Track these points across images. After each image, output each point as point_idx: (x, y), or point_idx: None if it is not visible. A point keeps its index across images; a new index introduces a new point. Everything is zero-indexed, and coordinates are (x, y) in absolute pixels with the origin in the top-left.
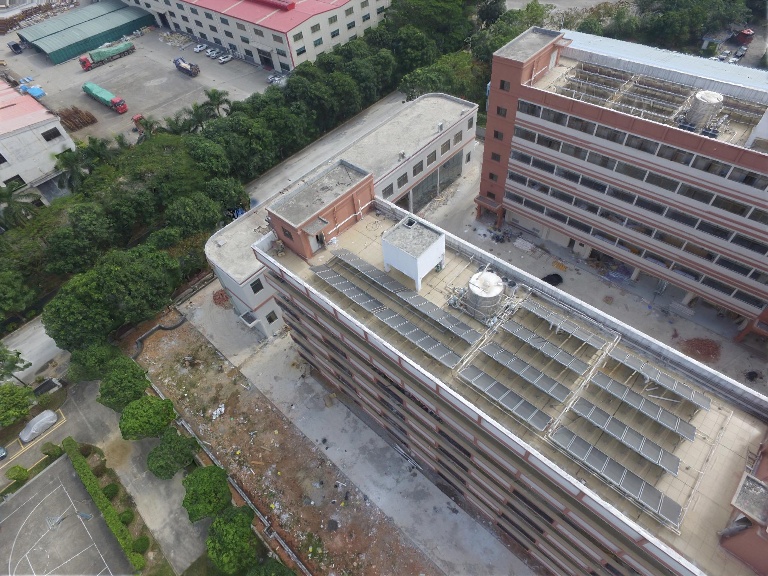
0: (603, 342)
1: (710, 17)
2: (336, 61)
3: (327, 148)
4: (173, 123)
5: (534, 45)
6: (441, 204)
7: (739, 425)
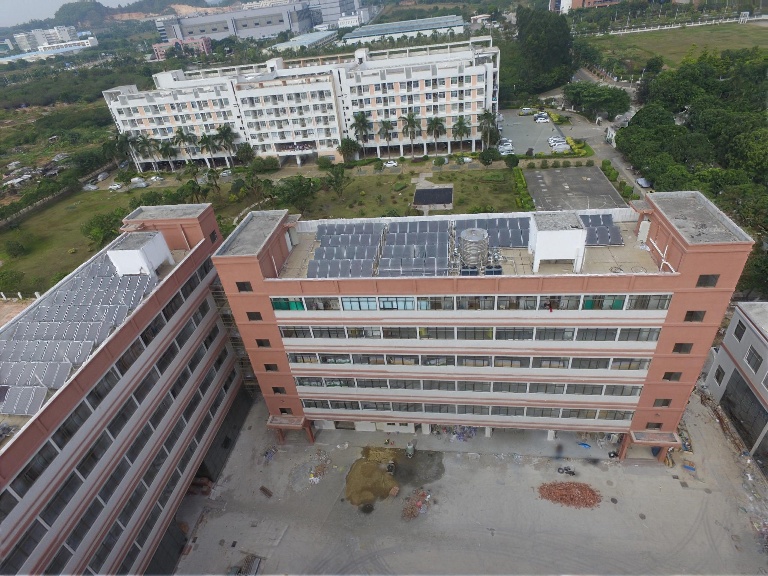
0: (380, 273)
1: None
2: None
3: None
4: None
5: None
6: None
7: None
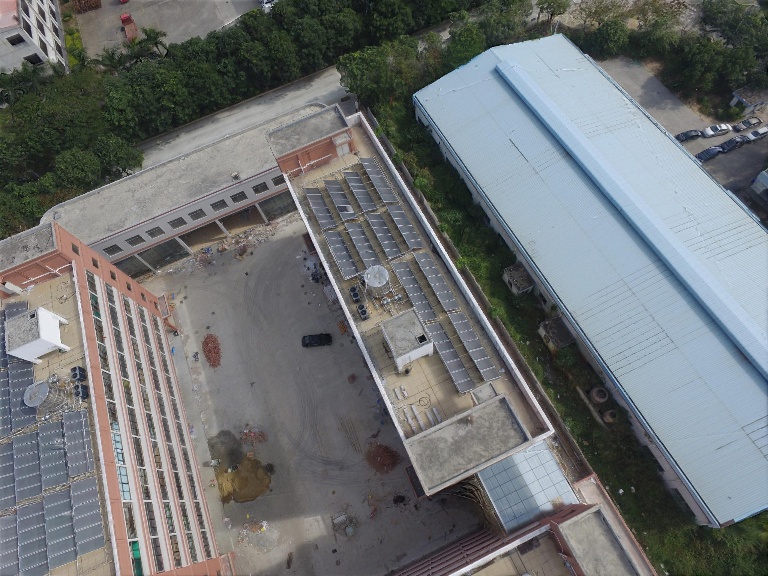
0: None
1: (759, 65)
2: (287, 16)
3: (259, 109)
4: (110, 56)
5: (316, 131)
6: (299, 218)
7: (105, 572)
